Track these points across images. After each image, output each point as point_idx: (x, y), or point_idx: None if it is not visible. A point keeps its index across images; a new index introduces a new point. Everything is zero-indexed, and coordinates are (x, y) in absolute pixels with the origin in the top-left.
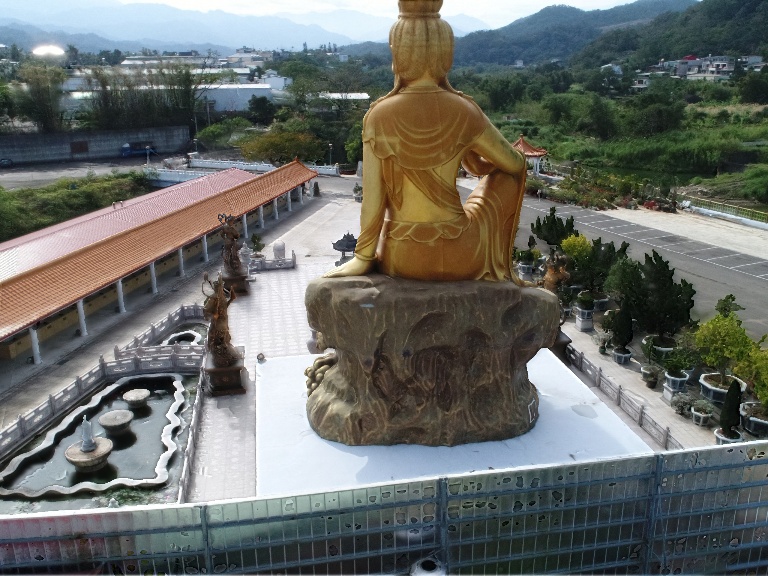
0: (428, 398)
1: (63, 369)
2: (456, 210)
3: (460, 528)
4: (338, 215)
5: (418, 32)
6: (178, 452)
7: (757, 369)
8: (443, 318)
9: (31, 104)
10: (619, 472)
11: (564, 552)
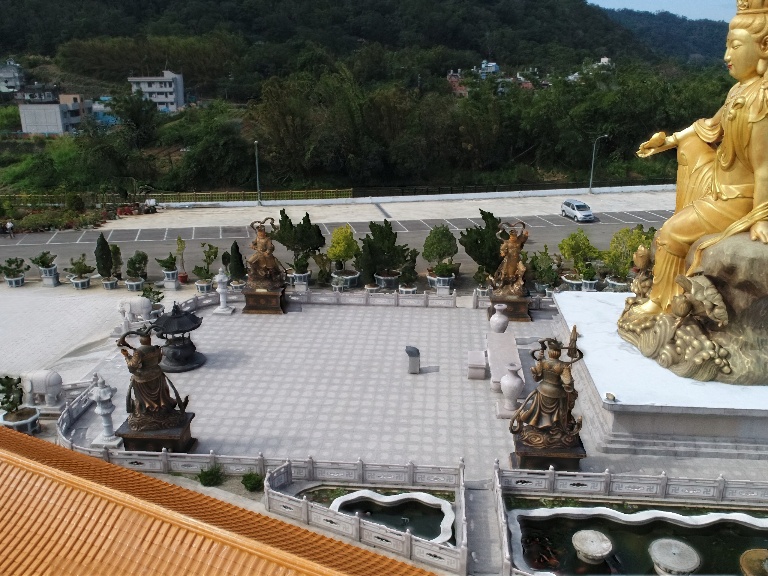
0: None
1: None
2: None
3: None
4: None
5: None
6: None
7: (615, 255)
8: None
9: None
10: None
11: None
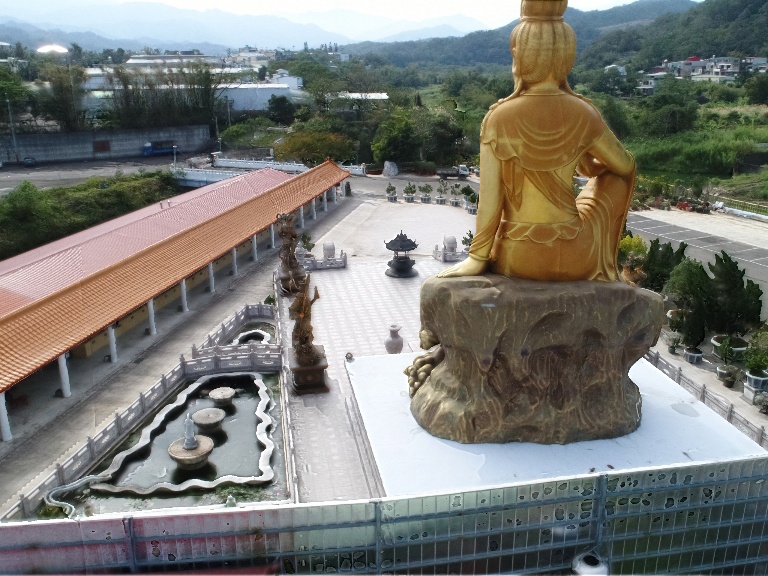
0: (542, 397)
1: (141, 368)
2: (573, 211)
3: (614, 524)
4: (374, 215)
5: (545, 35)
6: (277, 450)
7: None
8: (562, 318)
9: (54, 103)
10: (767, 469)
11: (710, 548)
